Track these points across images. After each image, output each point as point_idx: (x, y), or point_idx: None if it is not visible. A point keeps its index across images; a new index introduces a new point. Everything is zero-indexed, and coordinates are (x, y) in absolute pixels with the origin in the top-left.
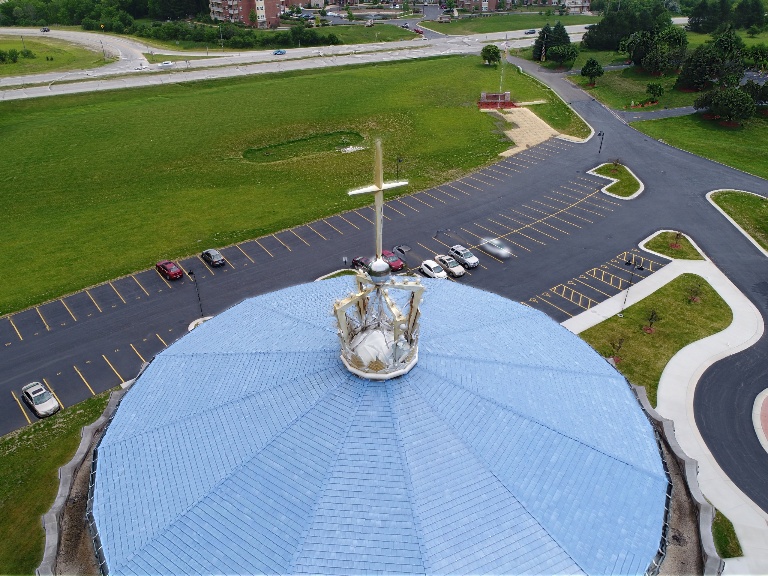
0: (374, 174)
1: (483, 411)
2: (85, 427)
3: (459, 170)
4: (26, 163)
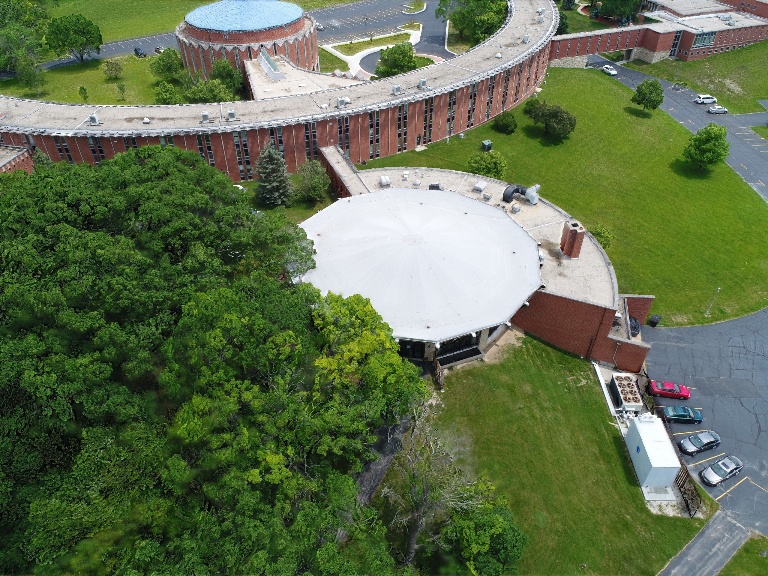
0: (300, 6)
1: (260, 5)
2: None
3: (342, 4)
4: (132, 2)
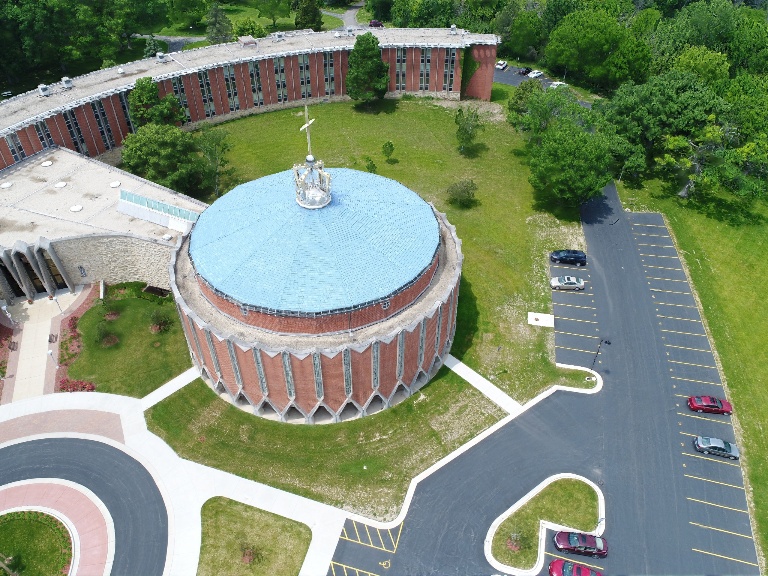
0: None
1: None
2: (431, 202)
3: None
4: None
